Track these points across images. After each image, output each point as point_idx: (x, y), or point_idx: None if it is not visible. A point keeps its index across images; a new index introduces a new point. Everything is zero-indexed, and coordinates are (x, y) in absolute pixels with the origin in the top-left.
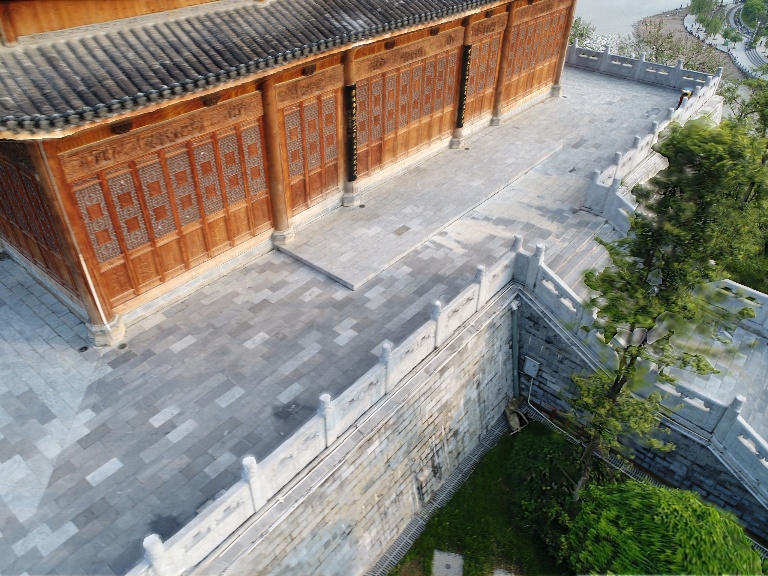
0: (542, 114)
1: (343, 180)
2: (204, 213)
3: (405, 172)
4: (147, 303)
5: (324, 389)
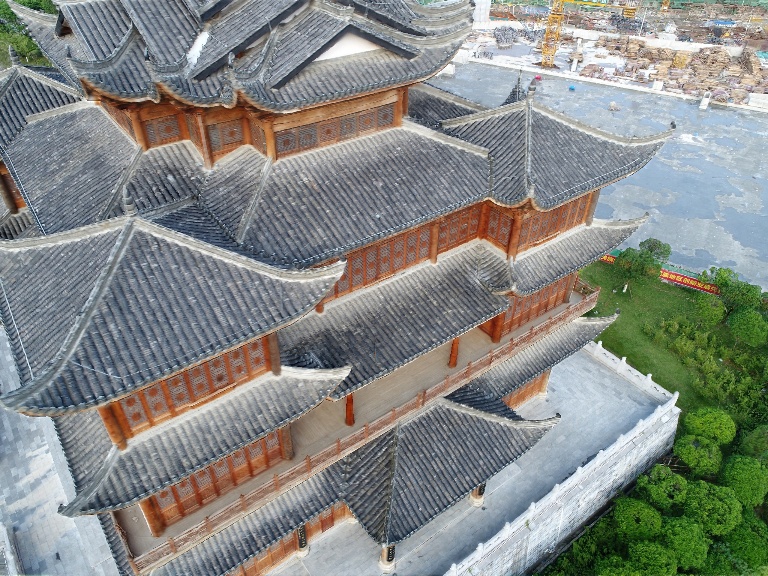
0: None
1: None
2: None
3: None
4: None
5: None
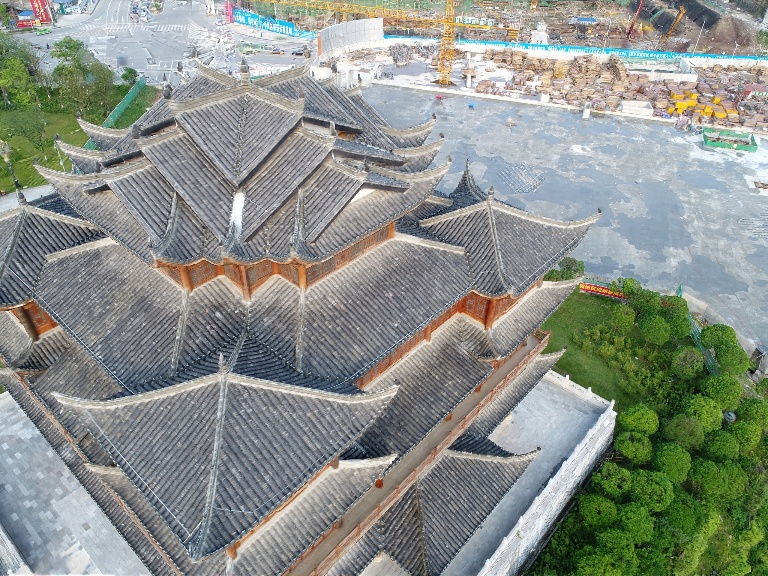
0: None
1: None
2: None
3: None
4: None
5: (5, 498)
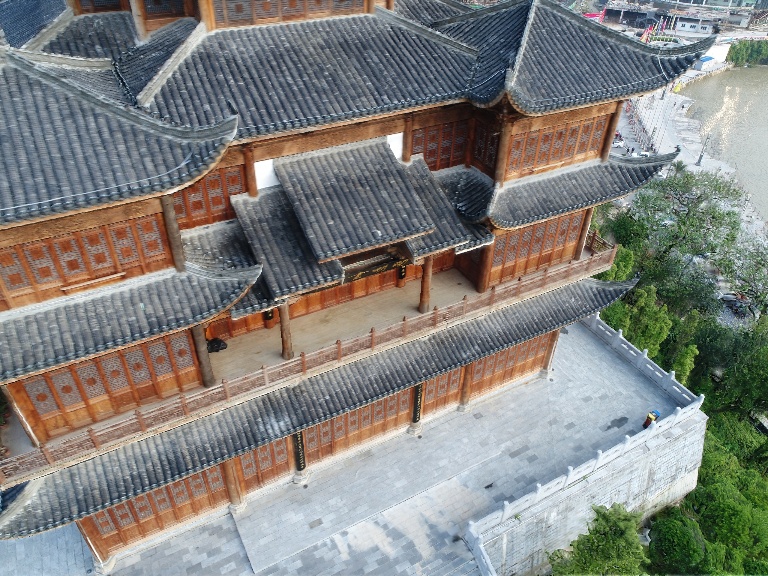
0: (515, 401)
1: (294, 468)
2: (175, 504)
3: (357, 454)
4: (132, 548)
5: None
